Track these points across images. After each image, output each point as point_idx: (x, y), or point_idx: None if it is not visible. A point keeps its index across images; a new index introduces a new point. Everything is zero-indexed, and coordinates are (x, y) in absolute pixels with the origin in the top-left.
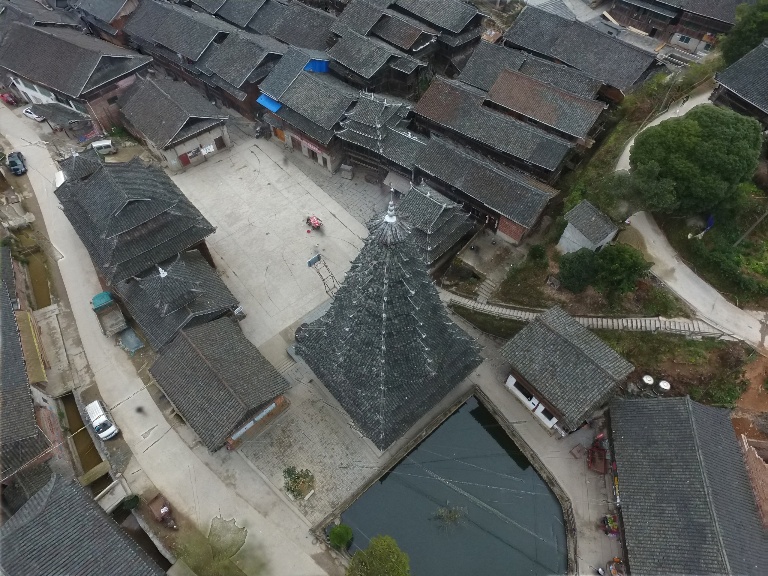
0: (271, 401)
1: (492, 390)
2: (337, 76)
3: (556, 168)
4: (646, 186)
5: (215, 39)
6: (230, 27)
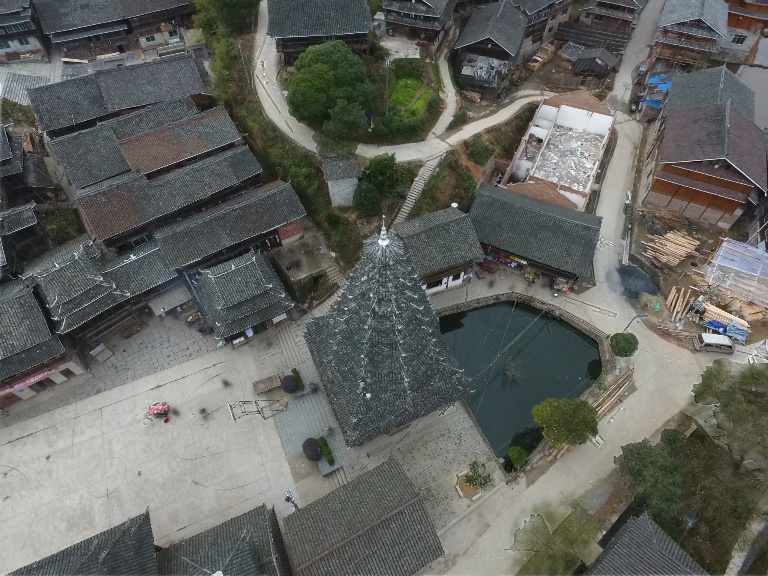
0: None
1: None
2: None
3: (261, 168)
4: (353, 116)
5: None
6: None
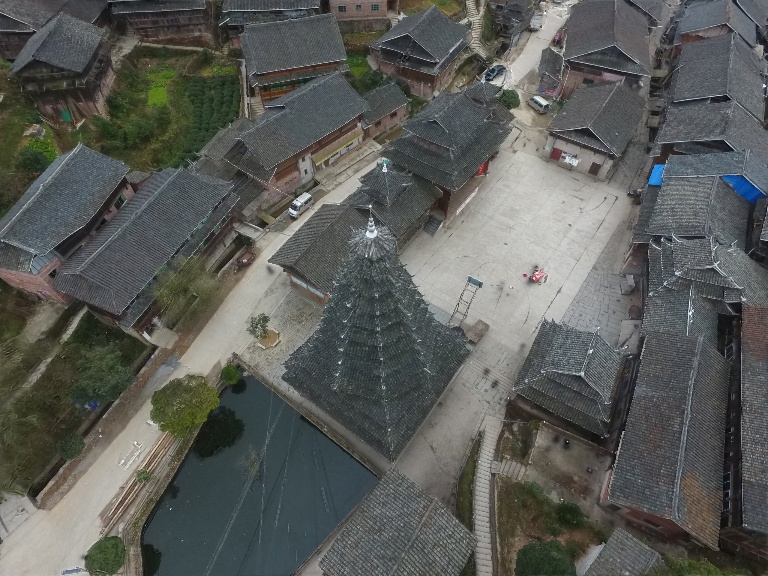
0: None
1: None
2: None
3: (752, 529)
4: None
5: (716, 98)
6: (755, 102)
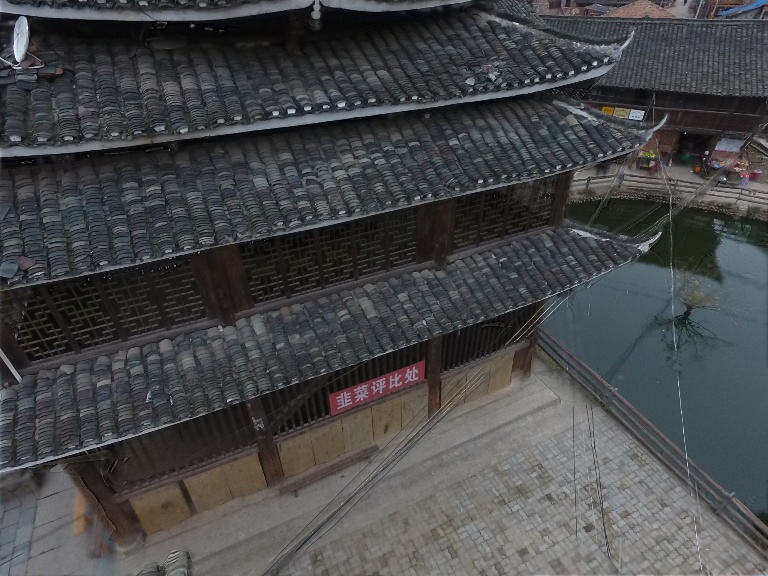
0: None
1: None
2: None
3: None
4: None
5: None
6: None
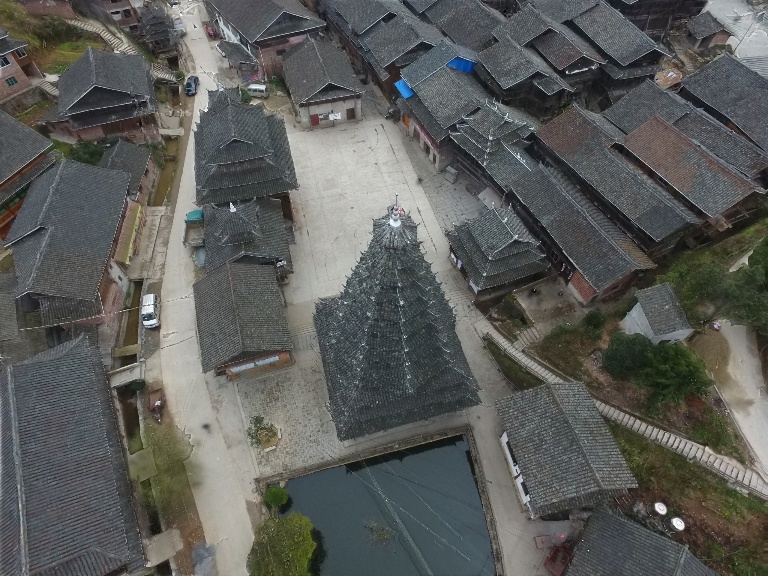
0: (275, 353)
1: (485, 438)
2: (479, 79)
3: (662, 239)
4: (737, 292)
5: (384, 18)
6: (404, 10)
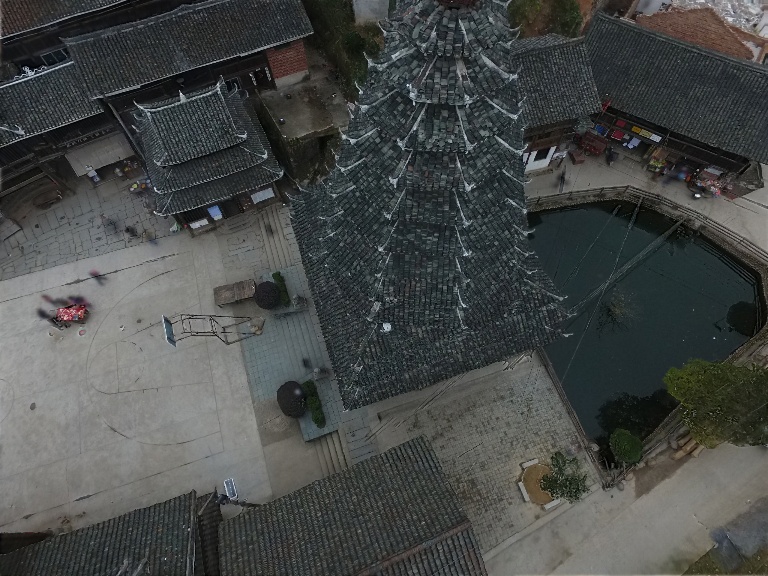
0: None
1: None
2: None
3: None
4: None
5: None
6: None
